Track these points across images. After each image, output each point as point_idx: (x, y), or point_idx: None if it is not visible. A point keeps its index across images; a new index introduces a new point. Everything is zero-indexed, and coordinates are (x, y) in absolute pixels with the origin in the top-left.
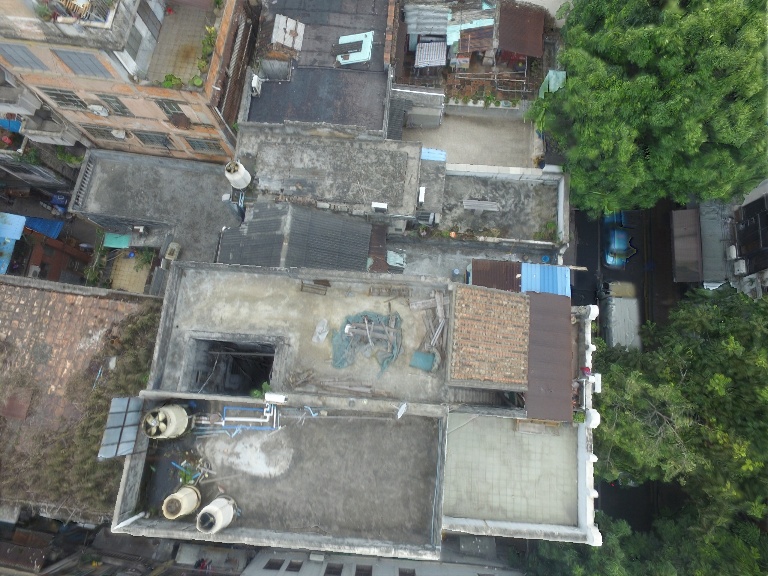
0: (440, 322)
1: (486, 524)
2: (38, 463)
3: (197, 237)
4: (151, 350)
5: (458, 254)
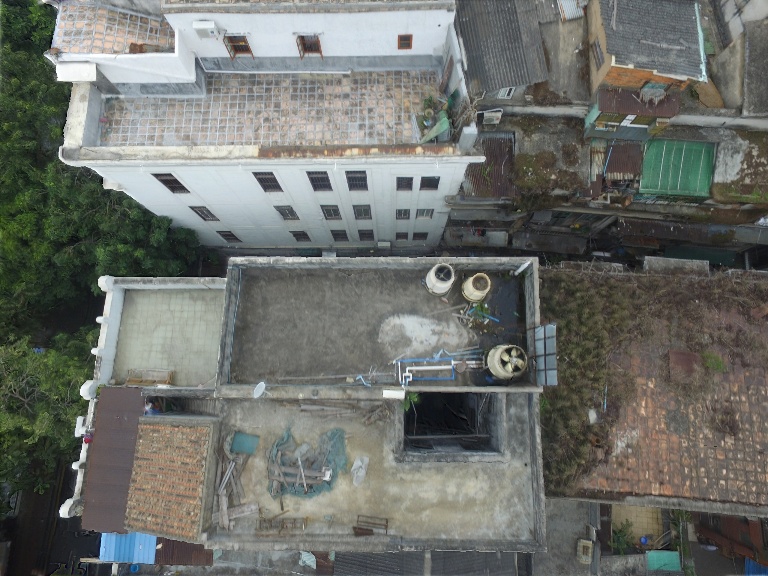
0: (224, 490)
1: (206, 286)
2: (638, 310)
3: (562, 573)
4: (554, 434)
5: (238, 569)
